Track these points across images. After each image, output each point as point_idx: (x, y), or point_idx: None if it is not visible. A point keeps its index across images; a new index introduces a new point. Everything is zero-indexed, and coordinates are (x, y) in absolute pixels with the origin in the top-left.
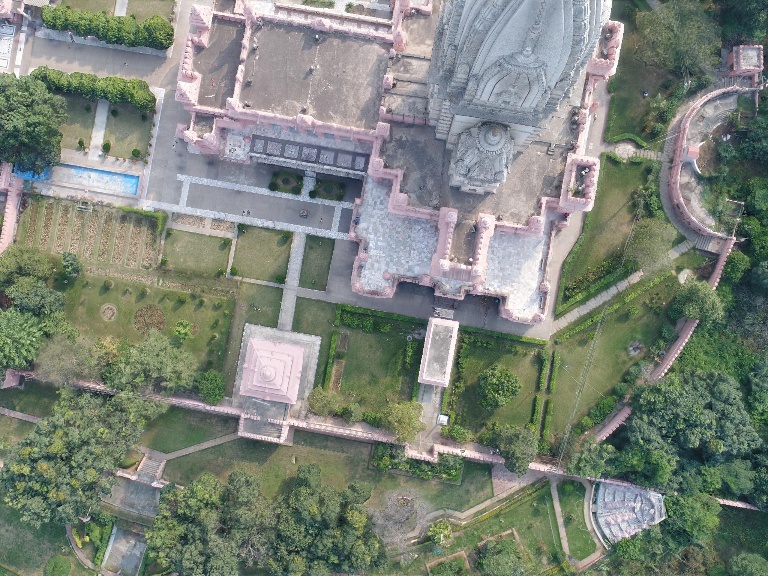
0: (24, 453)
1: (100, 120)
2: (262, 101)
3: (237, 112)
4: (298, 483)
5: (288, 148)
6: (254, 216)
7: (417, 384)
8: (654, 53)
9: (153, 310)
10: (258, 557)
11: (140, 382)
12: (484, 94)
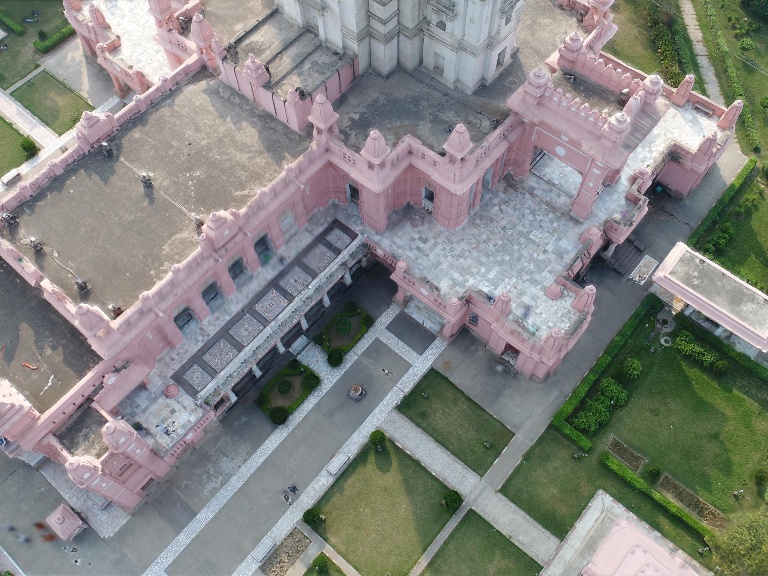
0: None
1: None
2: (131, 287)
3: (114, 334)
4: None
5: (237, 333)
6: (306, 484)
7: (760, 368)
8: None
9: None
10: None
11: None
12: None
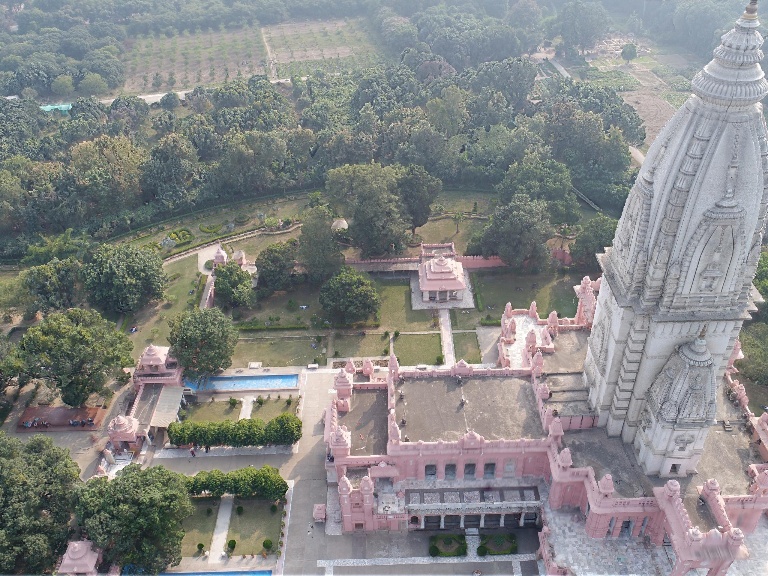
0: None
1: (222, 521)
2: (420, 436)
3: (398, 446)
4: None
5: (447, 496)
6: None
7: None
8: (755, 364)
9: None
10: None
11: None
12: (687, 281)
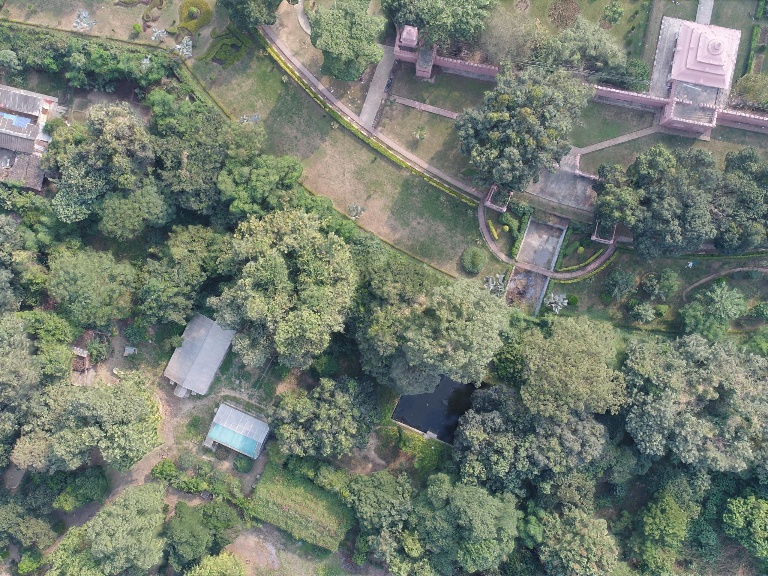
0: (506, 98)
1: None
2: None
3: None
4: (736, 164)
5: None
6: None
7: None
8: None
9: (568, 3)
10: (721, 220)
11: (576, 60)
12: None
